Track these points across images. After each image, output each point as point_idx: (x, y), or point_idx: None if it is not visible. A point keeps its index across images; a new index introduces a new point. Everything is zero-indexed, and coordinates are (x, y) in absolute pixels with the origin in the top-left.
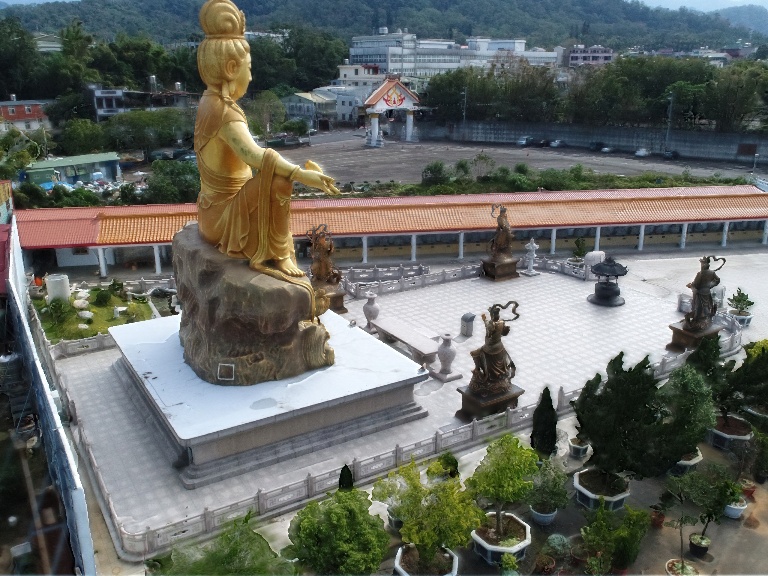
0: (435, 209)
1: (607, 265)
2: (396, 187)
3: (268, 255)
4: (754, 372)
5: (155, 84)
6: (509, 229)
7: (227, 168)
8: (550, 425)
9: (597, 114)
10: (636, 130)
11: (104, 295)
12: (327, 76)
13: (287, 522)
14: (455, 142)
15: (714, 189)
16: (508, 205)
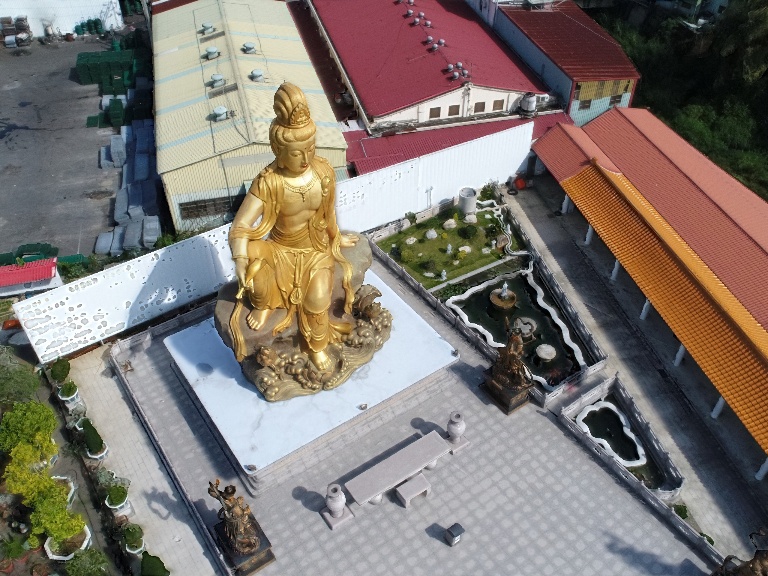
0: None
1: None
2: None
3: None
4: None
5: None
6: None
7: None
8: None
9: None
10: None
11: (467, 230)
12: None
13: (131, 420)
14: None
15: None
16: None
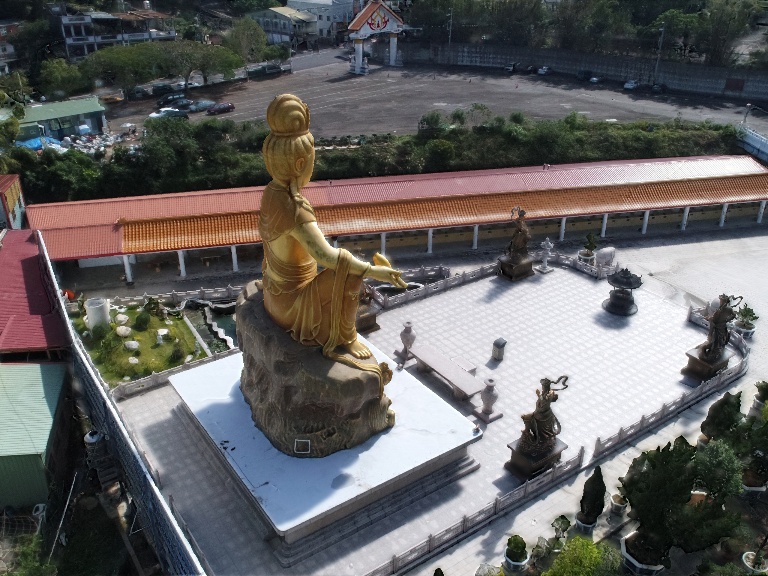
0: (450, 201)
1: (624, 277)
2: (392, 139)
3: (339, 342)
4: None
5: (122, 3)
6: (527, 231)
7: (295, 257)
8: (600, 497)
9: (586, 41)
10: (625, 59)
11: (144, 319)
12: None
13: None
14: (440, 66)
15: (713, 162)
16: (520, 194)
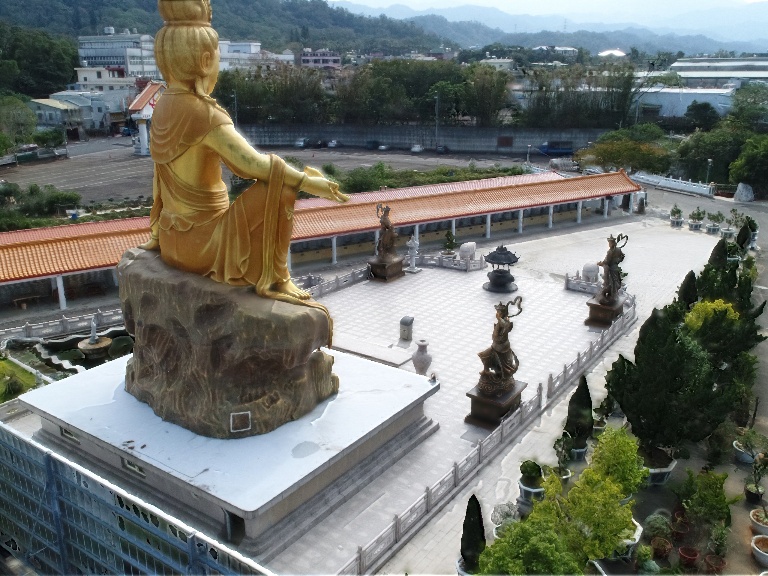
0: (304, 215)
1: (502, 254)
2: None
3: (273, 278)
4: (715, 332)
5: None
6: (393, 228)
7: (206, 181)
8: (590, 412)
9: (369, 114)
10: (407, 128)
11: None
12: (57, 80)
13: (391, 575)
14: None
15: (526, 177)
16: (371, 205)
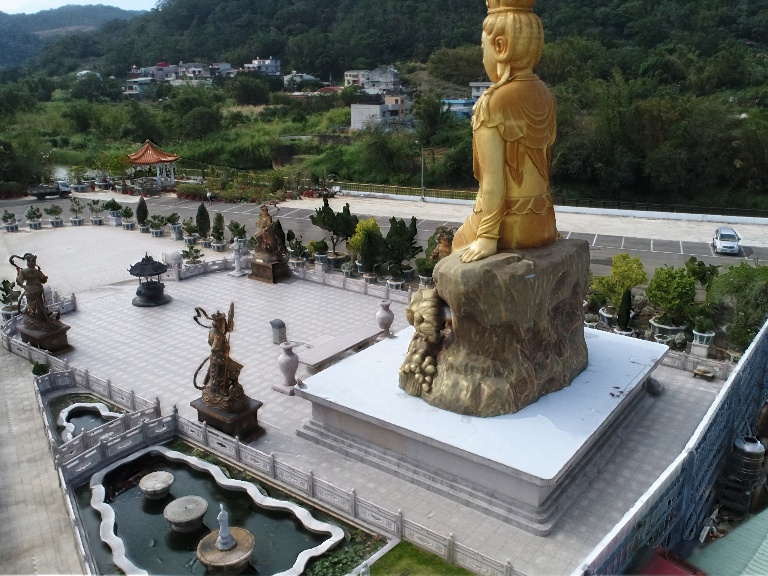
0: None
1: (155, 263)
2: None
3: None
4: (403, 231)
5: None
6: None
7: None
8: None
9: None
10: None
11: None
12: None
13: None
14: None
15: None
16: None
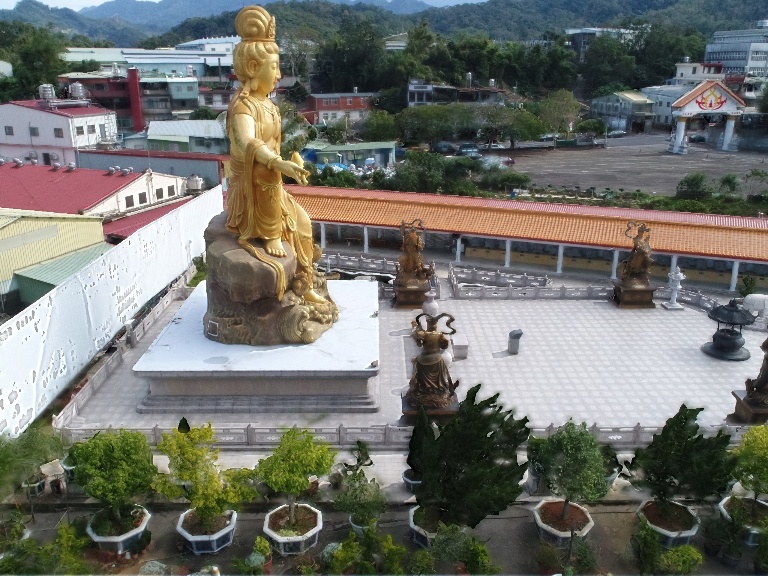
0: (593, 221)
1: (726, 309)
2: (643, 197)
3: (255, 233)
4: None
5: (470, 80)
6: (647, 252)
7: None
8: (419, 445)
9: None
10: None
11: None
12: None
13: None
14: None
15: None
16: (684, 227)
